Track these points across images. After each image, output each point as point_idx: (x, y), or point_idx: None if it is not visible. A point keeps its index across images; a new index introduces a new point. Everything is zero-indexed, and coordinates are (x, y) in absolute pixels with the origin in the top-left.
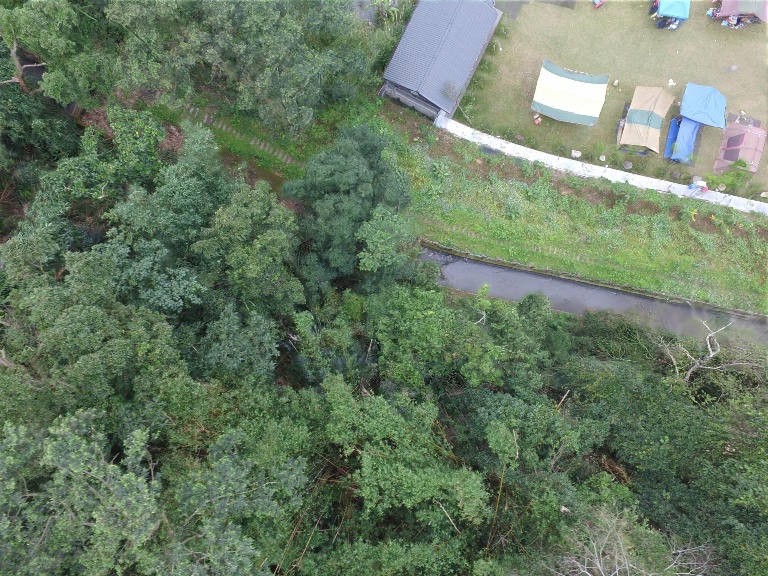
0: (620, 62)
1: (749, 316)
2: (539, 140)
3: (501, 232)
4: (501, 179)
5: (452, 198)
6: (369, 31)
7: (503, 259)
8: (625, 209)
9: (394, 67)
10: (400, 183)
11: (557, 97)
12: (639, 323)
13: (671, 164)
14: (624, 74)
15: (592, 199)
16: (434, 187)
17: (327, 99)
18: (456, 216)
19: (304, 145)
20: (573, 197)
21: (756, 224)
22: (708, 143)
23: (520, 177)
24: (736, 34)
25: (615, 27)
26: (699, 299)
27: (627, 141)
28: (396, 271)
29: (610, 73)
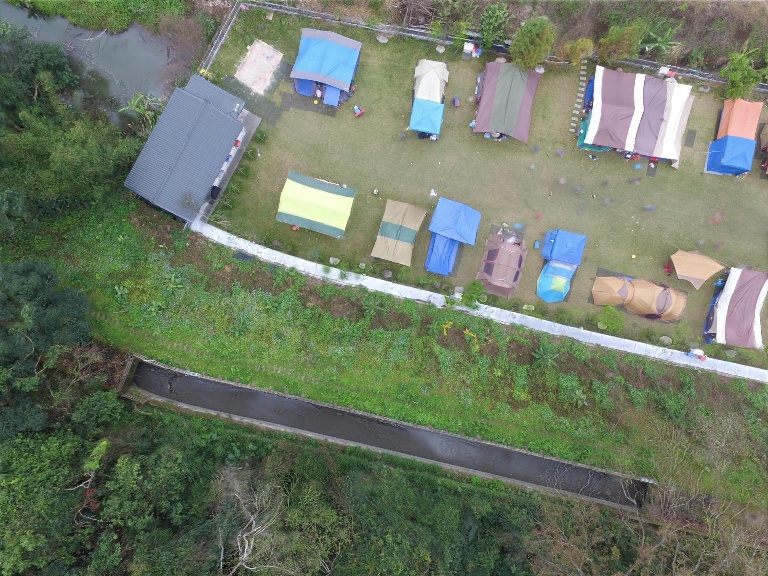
0: (381, 171)
1: (475, 443)
2: (297, 246)
3: (223, 350)
4: (245, 289)
5: (178, 313)
6: (118, 136)
7: (224, 377)
8: (371, 322)
9: (134, 176)
10: (119, 299)
11: (306, 208)
12: (307, 468)
13: (432, 274)
14: (385, 183)
15: (341, 310)
16: (155, 303)
17: (70, 204)
18: (177, 333)
19: (22, 258)
20: (316, 310)
21: (512, 339)
22: (470, 254)
23: (269, 286)
24: (499, 146)
25: (376, 136)
26: (425, 423)
27: (377, 254)
28: (19, 423)
29: (371, 182)
